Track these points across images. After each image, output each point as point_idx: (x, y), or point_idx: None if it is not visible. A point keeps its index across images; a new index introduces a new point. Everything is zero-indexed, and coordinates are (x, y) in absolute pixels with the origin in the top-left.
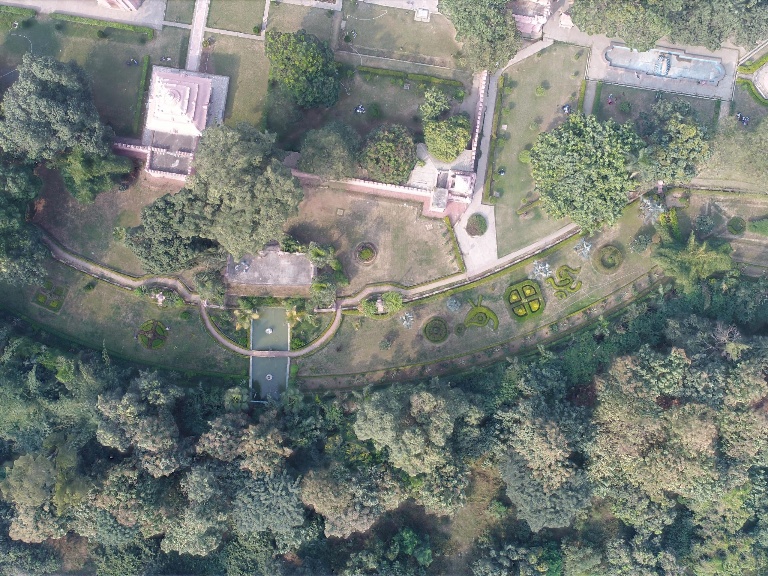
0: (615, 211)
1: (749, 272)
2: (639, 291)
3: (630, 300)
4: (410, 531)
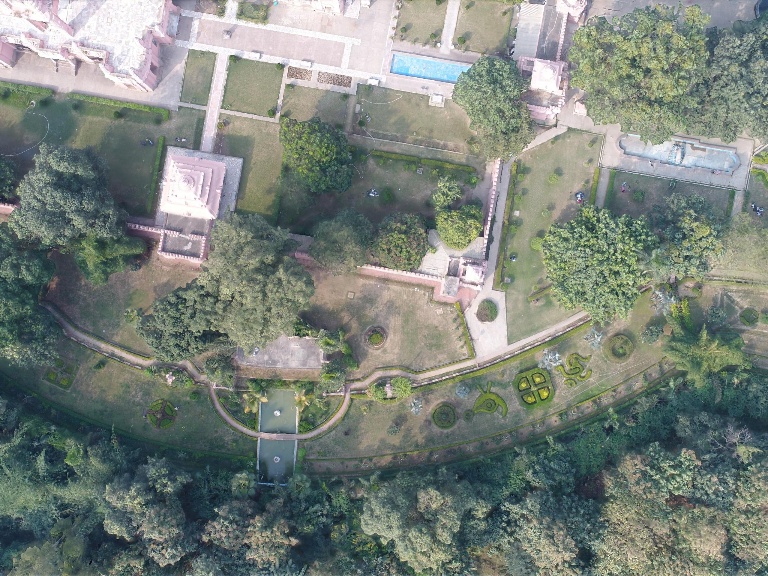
0: (627, 305)
1: (761, 364)
2: (649, 381)
3: (640, 390)
4: None
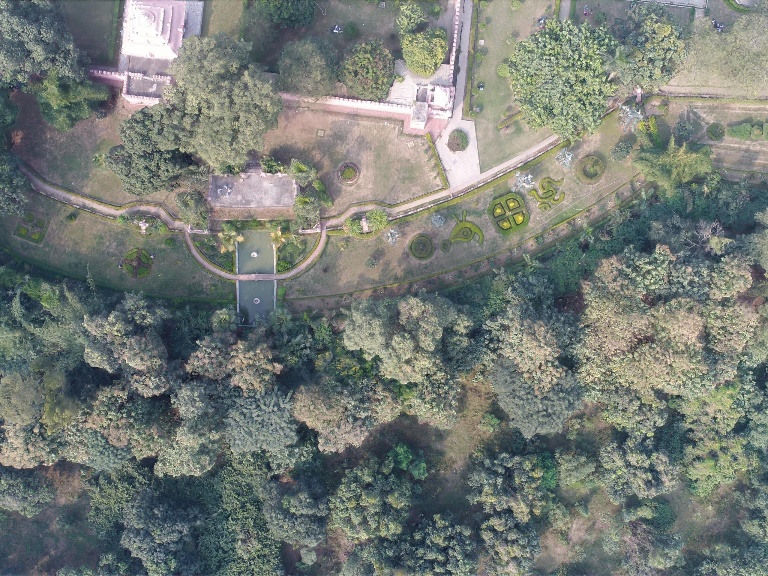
0: (595, 116)
1: (730, 177)
2: (622, 200)
3: (613, 209)
4: (404, 446)
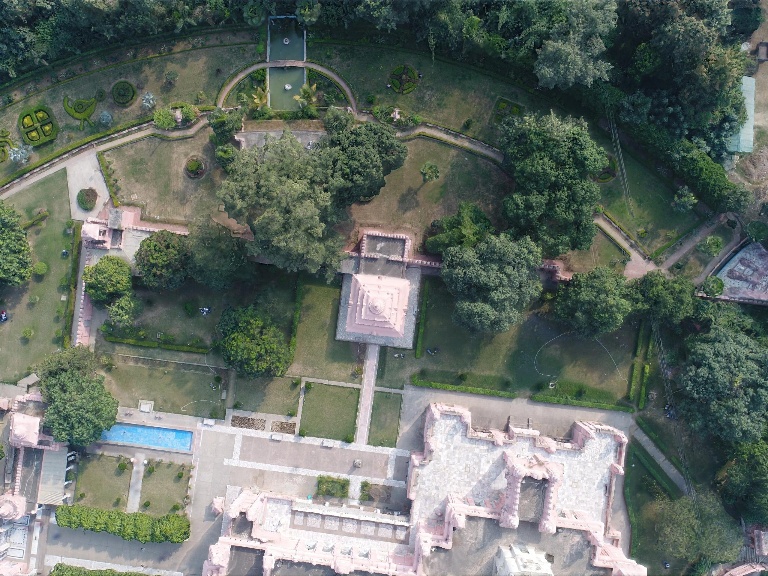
0: None
1: None
2: None
3: None
4: None
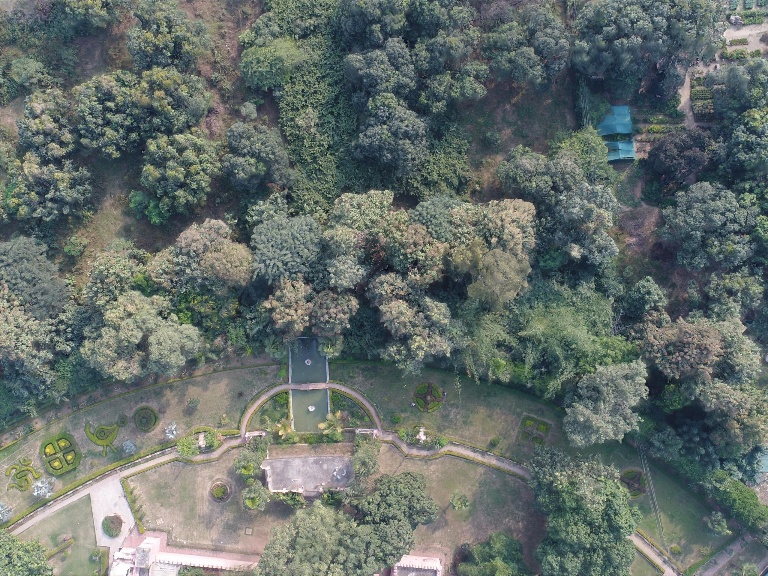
0: None
1: None
2: None
3: None
4: None
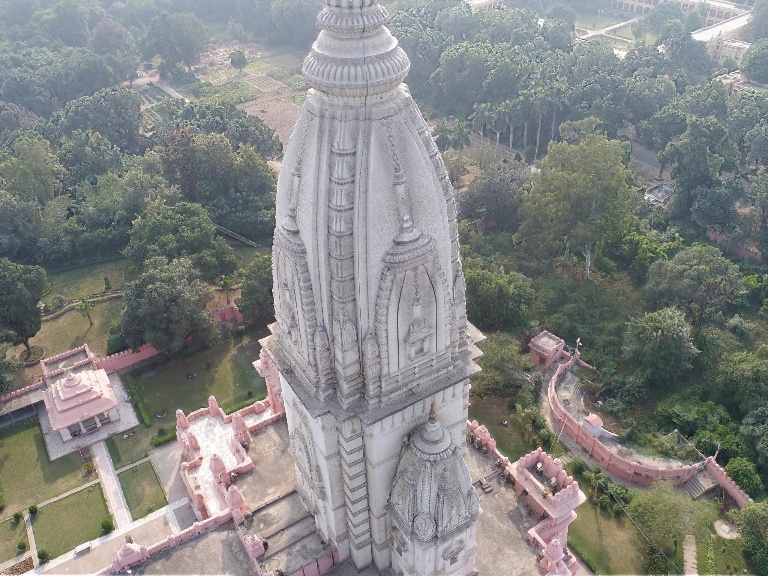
0: None
1: None
2: None
3: None
4: None
